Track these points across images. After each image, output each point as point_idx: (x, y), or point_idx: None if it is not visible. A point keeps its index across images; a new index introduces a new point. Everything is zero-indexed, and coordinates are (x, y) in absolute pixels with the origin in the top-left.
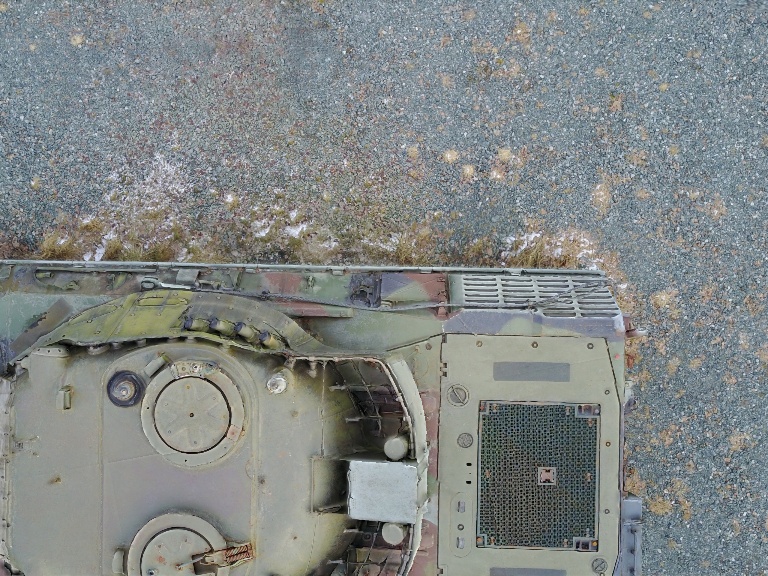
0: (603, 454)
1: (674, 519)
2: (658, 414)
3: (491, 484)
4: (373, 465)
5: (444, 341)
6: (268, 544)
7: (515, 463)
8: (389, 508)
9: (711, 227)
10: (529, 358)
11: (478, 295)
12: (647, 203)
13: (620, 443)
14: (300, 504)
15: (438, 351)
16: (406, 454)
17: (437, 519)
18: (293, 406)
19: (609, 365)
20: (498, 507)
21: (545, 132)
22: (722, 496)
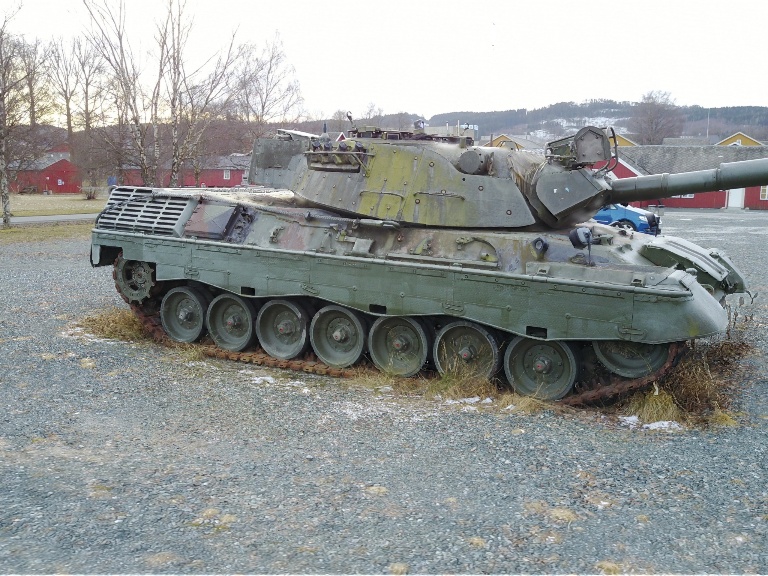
0: None
1: None
2: None
3: None
4: (301, 133)
5: None
6: None
7: None
8: None
9: None
10: None
11: (177, 209)
12: (0, 333)
13: None
14: None
15: None
16: None
17: None
18: None
19: None
20: None
21: (3, 356)
22: None
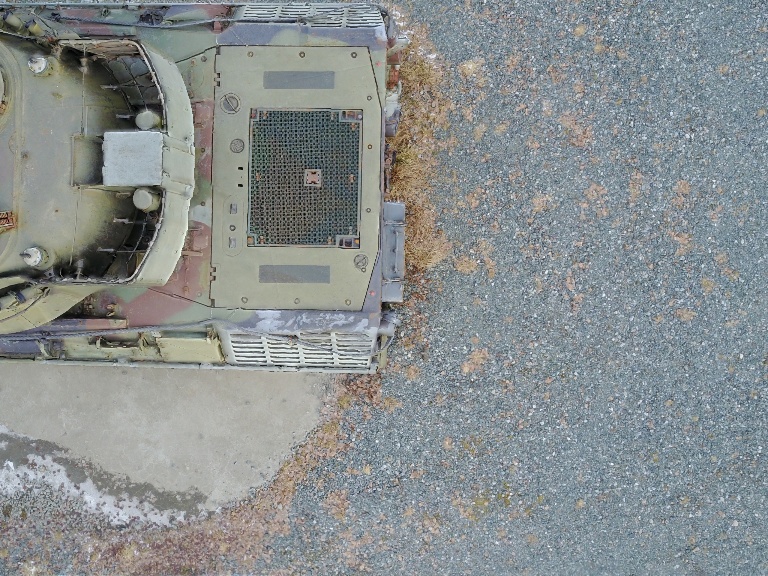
0: (365, 156)
1: (479, 277)
2: (465, 178)
3: (261, 187)
4: (123, 133)
5: (218, 53)
6: (30, 216)
7: (283, 166)
8: (137, 172)
9: (517, 0)
10: (297, 67)
11: (256, 16)
12: None
13: (381, 146)
14: (61, 179)
15: (212, 62)
16: (158, 127)
17: (211, 221)
18: (57, 90)
19: (372, 73)
20: (267, 208)
21: None
22: (525, 255)
